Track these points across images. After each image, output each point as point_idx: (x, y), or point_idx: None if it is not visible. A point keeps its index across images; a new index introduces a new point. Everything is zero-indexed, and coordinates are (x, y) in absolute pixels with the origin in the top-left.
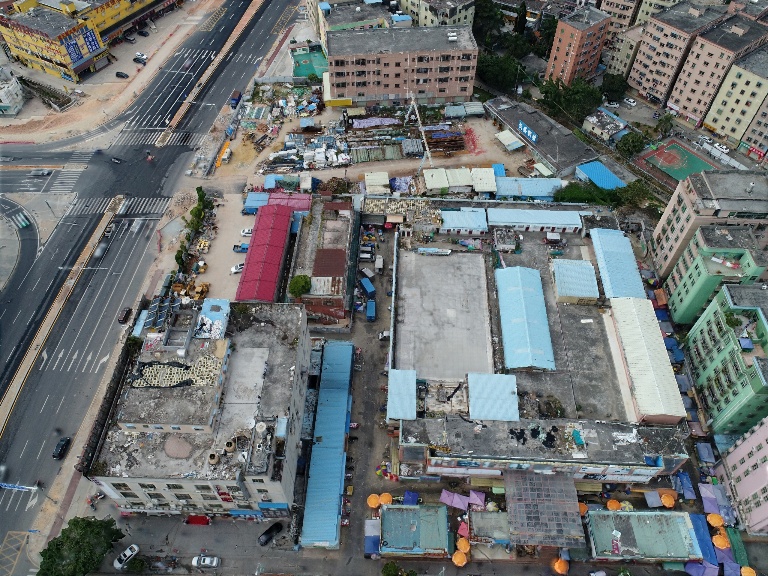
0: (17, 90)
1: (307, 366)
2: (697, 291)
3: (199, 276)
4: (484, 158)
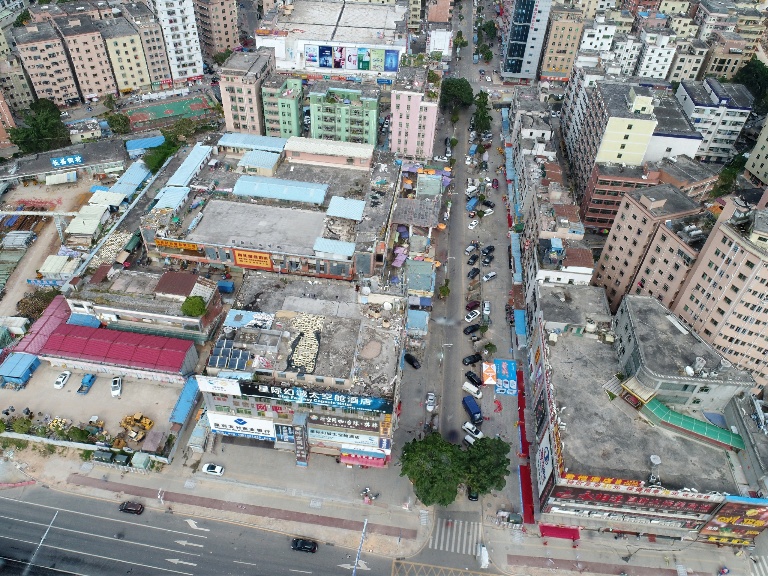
0: None
1: None
2: (296, 115)
3: (106, 429)
4: (69, 200)
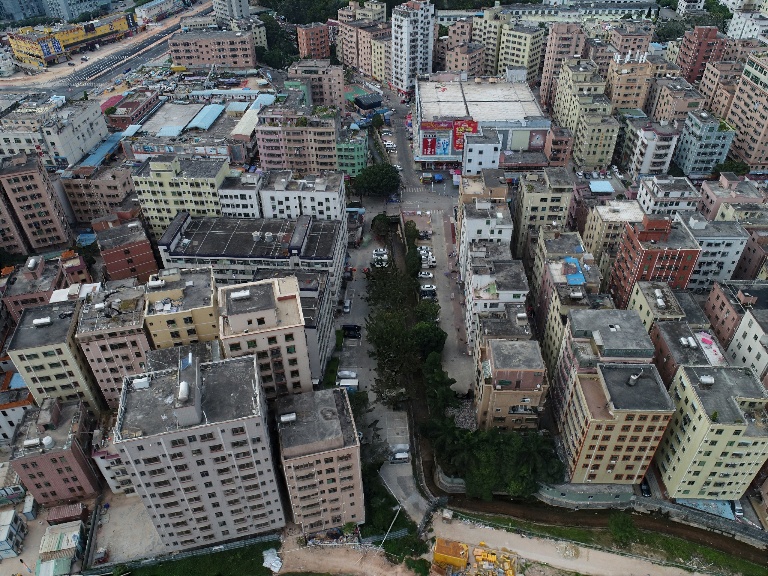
0: (10, 64)
1: (101, 134)
2: None
3: None
4: None
